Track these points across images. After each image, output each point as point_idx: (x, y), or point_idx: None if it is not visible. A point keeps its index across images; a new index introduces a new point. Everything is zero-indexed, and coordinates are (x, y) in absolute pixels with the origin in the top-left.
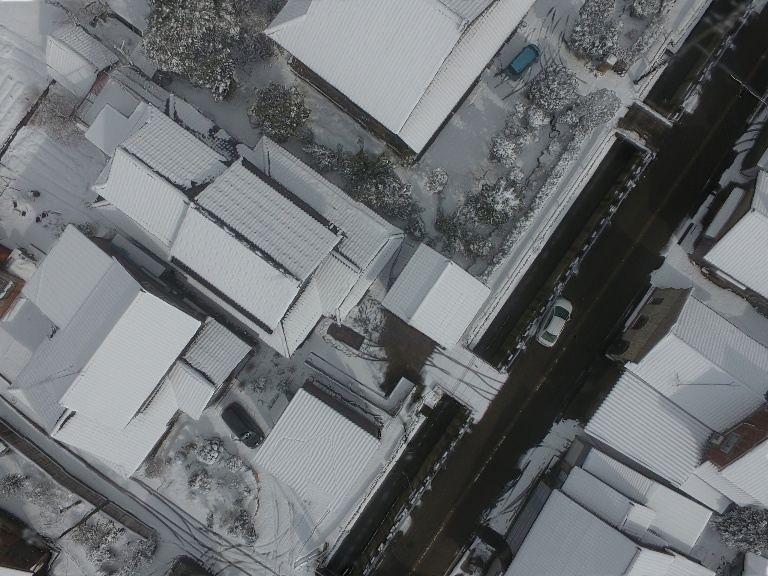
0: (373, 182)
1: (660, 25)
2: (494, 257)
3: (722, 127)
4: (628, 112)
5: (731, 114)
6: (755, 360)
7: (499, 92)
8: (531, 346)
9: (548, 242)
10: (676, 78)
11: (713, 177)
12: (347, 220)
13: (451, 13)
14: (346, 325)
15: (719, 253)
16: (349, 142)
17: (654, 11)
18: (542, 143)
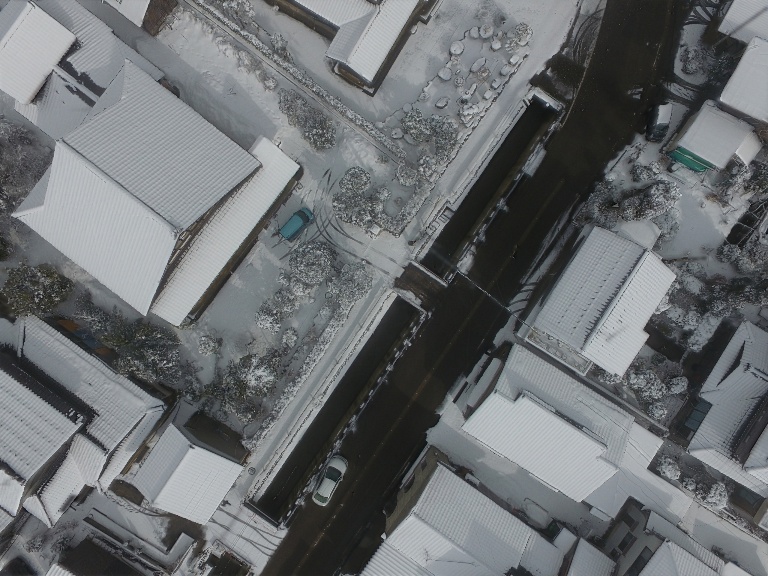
0: (127, 359)
1: (421, 197)
2: (263, 422)
3: (495, 288)
4: (404, 272)
5: (504, 275)
6: (503, 535)
7: (276, 252)
8: (310, 502)
9: (332, 396)
10: (459, 233)
11: (487, 337)
12: (102, 396)
13: (162, 223)
14: (127, 481)
15: (473, 426)
16: (125, 303)
17: (416, 182)
18: (319, 303)
